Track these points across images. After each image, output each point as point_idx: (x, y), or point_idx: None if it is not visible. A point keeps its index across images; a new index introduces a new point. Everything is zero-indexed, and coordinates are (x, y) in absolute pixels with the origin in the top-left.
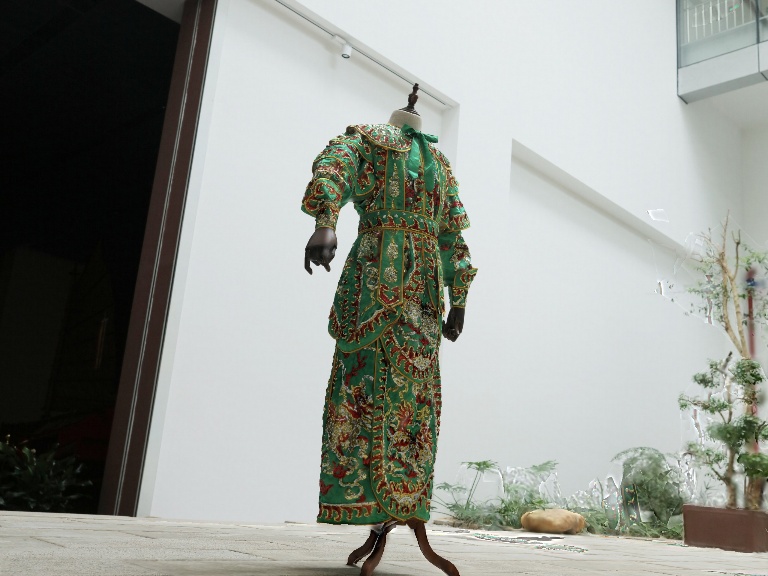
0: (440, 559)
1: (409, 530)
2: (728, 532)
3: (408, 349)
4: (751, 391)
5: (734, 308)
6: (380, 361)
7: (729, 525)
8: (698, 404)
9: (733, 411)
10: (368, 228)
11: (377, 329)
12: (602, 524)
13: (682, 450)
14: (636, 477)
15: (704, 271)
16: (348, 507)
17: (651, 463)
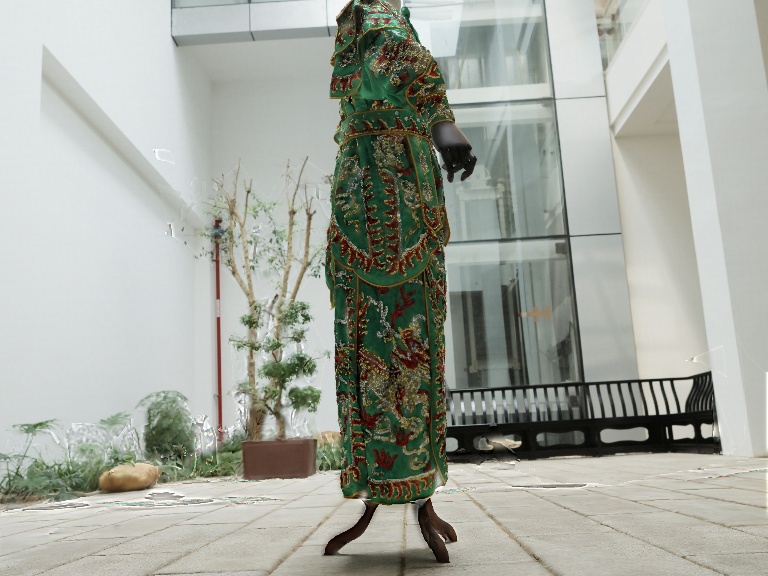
0: (443, 523)
1: (47, 513)
2: (285, 462)
3: (443, 283)
4: (300, 330)
5: (243, 253)
6: (430, 297)
7: (286, 455)
8: (247, 344)
9: (286, 349)
10: (381, 130)
11: (425, 258)
12: (163, 473)
13: (232, 390)
14: (163, 422)
15: (215, 216)
16: (416, 479)
17: (175, 406)
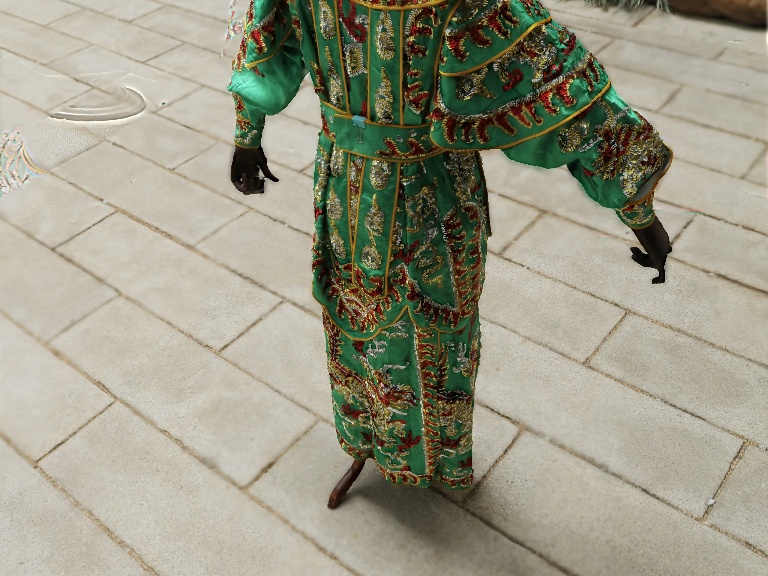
0: None
1: None
2: None
3: None
4: None
5: None
6: None
7: None
8: None
9: None
10: None
11: None
12: None
13: None
14: None
15: None
16: None
17: None
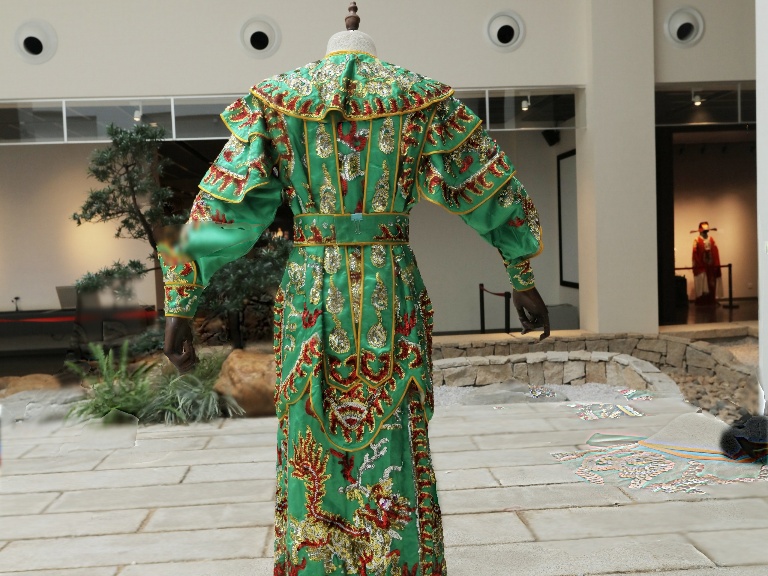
0: None
1: None
2: None
3: None
4: None
5: None
6: None
7: None
8: None
9: None
10: None
11: None
12: None
13: None
14: None
15: None
16: None
17: None
